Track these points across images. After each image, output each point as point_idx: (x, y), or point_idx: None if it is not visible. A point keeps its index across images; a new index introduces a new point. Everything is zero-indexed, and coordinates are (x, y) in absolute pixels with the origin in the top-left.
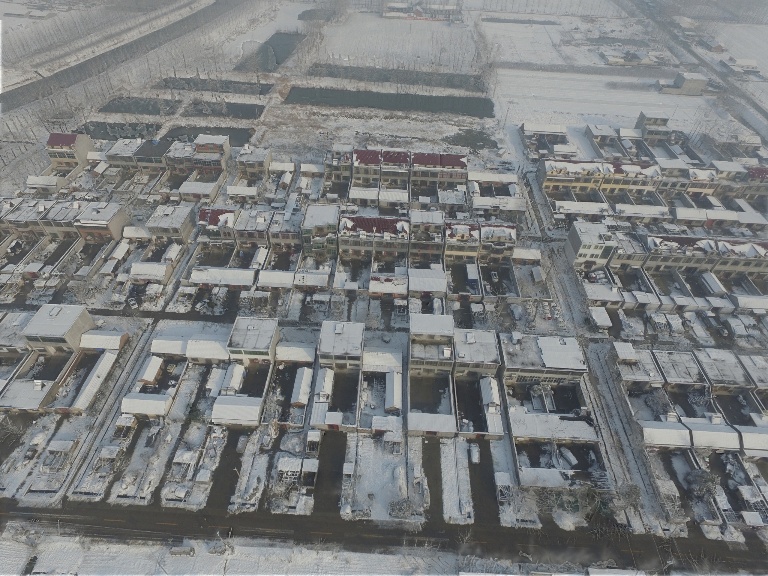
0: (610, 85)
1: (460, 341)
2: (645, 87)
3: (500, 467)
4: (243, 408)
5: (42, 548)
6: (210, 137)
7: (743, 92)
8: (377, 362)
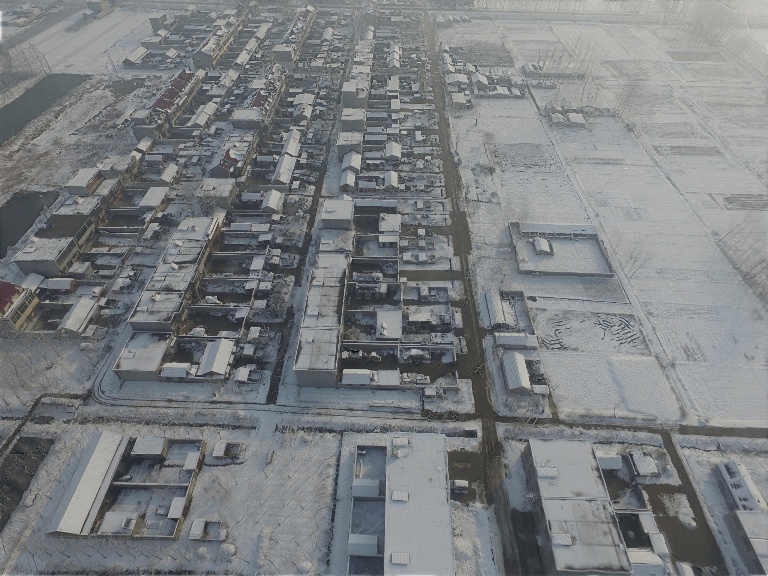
0: (70, 30)
1: None
2: (84, 21)
3: None
4: (394, 147)
5: None
6: (77, 178)
7: None
8: None
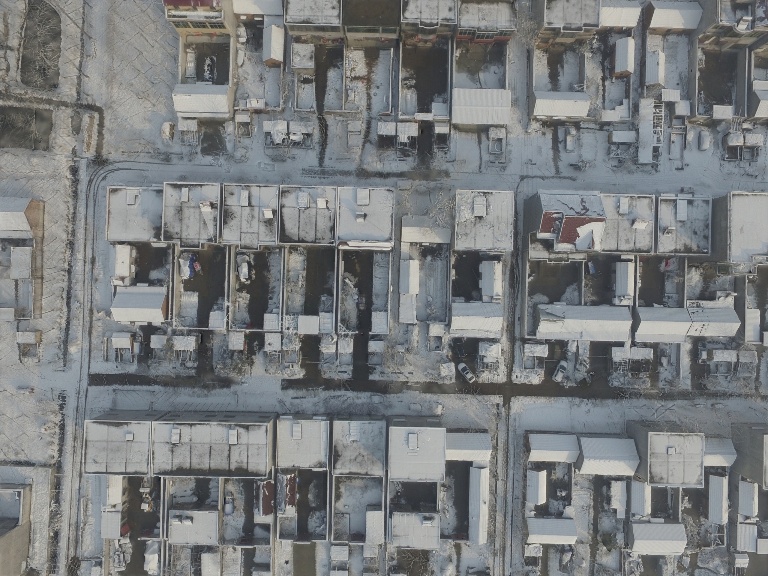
0: None
1: None
2: None
3: None
4: (668, 543)
5: None
6: None
7: None
8: None
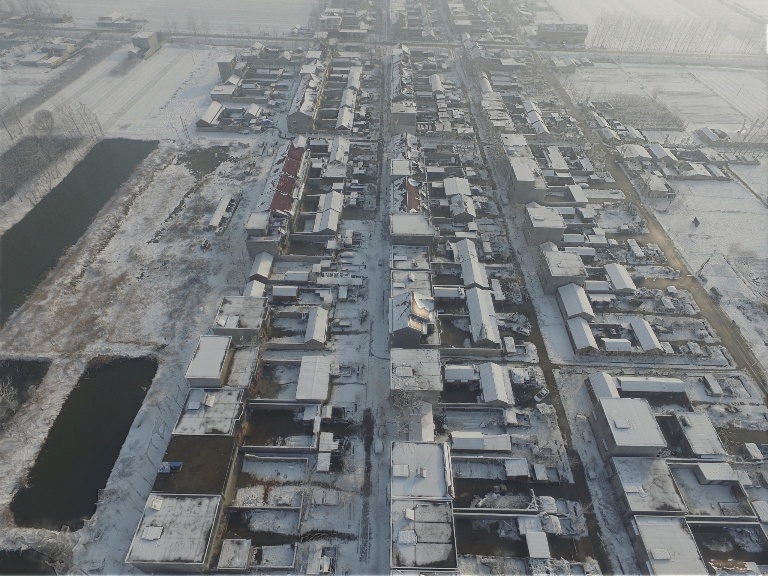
0: (116, 74)
1: None
2: (130, 61)
3: None
4: (621, 272)
5: None
6: (201, 359)
7: (198, 25)
8: None
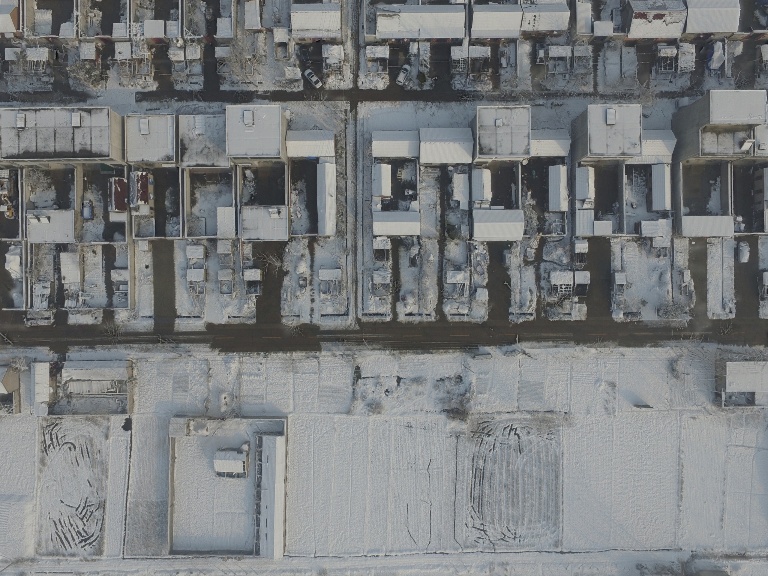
0: None
1: (762, 124)
2: None
3: (766, 264)
4: (507, 225)
5: (360, 360)
6: None
7: None
8: (644, 152)
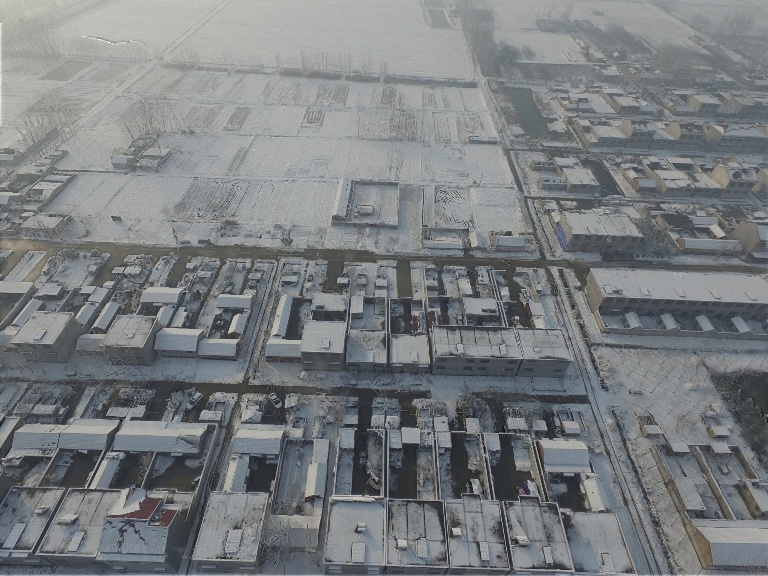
0: None
1: None
2: None
3: None
4: (156, 292)
5: None
6: None
7: None
8: None
